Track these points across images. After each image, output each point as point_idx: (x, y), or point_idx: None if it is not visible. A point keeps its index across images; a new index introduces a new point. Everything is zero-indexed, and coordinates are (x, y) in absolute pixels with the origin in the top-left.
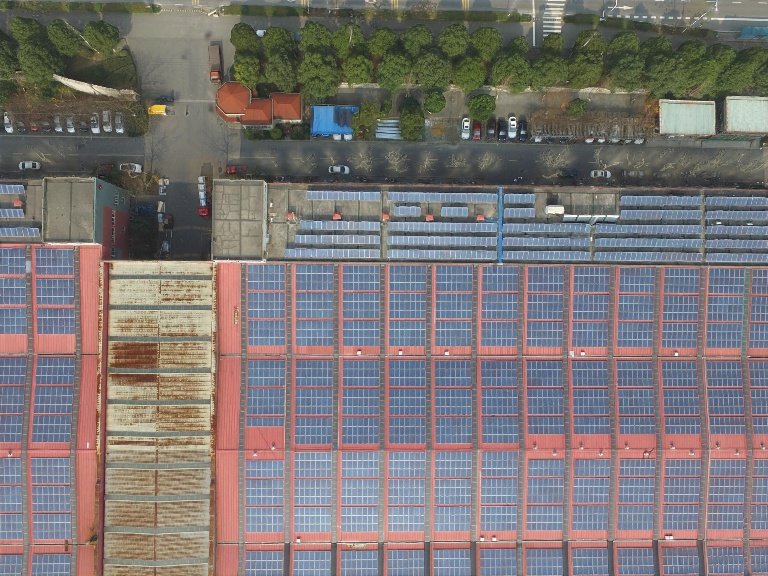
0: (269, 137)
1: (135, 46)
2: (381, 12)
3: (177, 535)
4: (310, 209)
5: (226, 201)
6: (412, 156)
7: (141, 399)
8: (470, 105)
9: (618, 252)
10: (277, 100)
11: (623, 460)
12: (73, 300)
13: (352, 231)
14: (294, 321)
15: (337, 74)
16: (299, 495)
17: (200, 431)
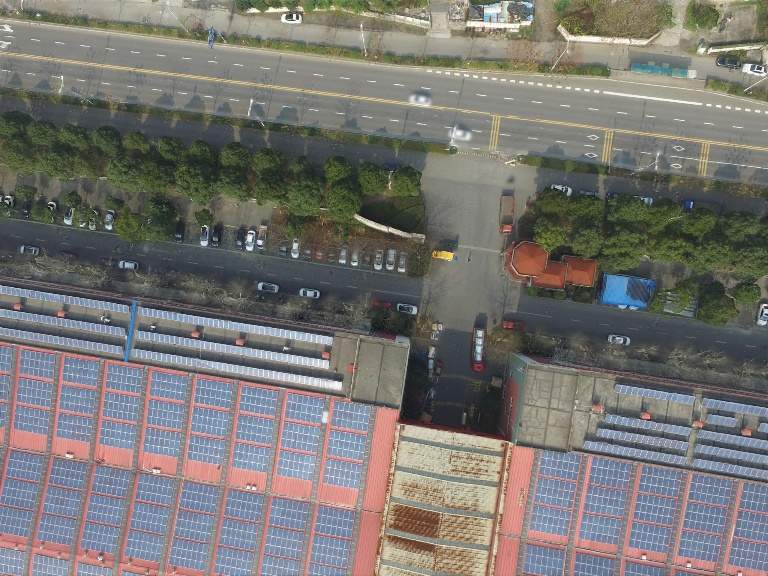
0: (551, 296)
1: (426, 185)
2: (688, 180)
3: None
4: (615, 401)
5: (537, 386)
6: (699, 335)
7: (416, 566)
8: None
9: None
10: (572, 265)
11: None
12: (362, 456)
13: (657, 431)
14: (581, 513)
15: None
16: None
17: None
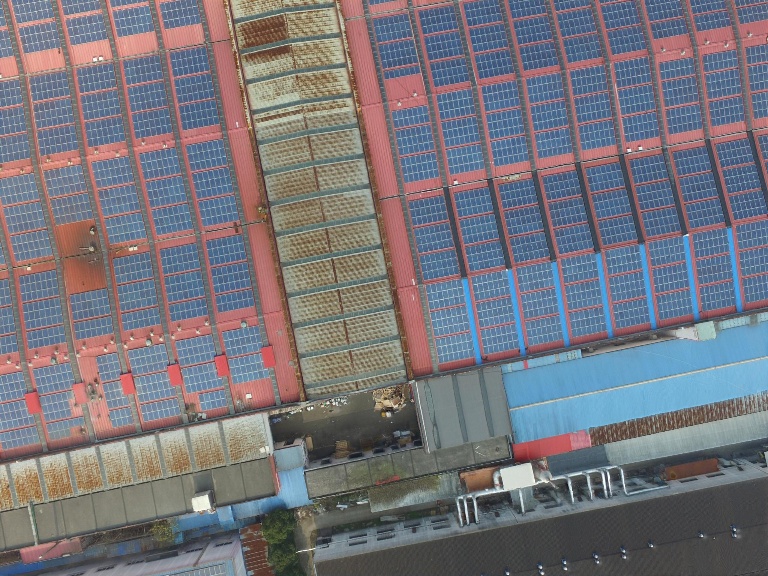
0: None
1: None
2: None
3: (340, 196)
4: None
5: None
6: None
7: (279, 72)
8: None
9: None
10: None
11: (748, 48)
12: None
13: None
14: None
15: None
16: (448, 137)
17: (341, 94)
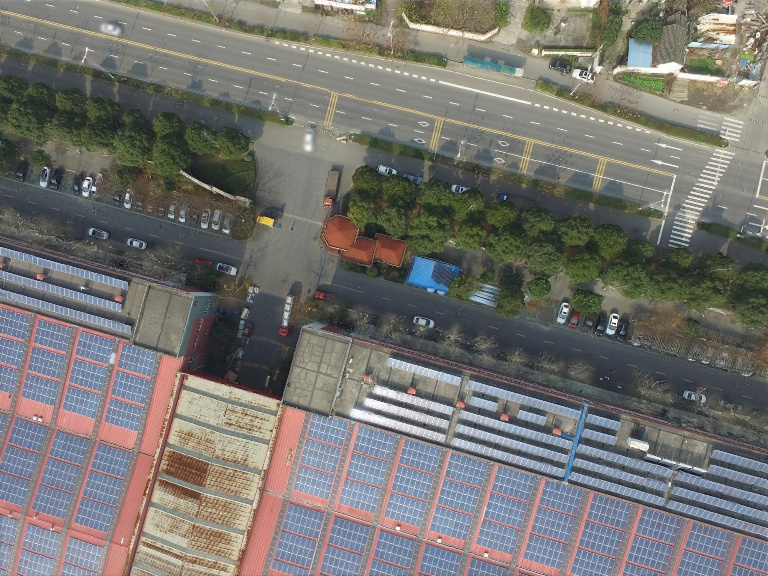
0: (364, 272)
1: (261, 152)
2: (507, 175)
3: None
4: (387, 374)
5: (309, 350)
6: (501, 326)
7: (181, 512)
8: (575, 299)
9: (695, 507)
10: (382, 243)
11: None
12: (144, 400)
13: (423, 408)
14: (343, 479)
15: (447, 234)
16: None
17: (227, 558)
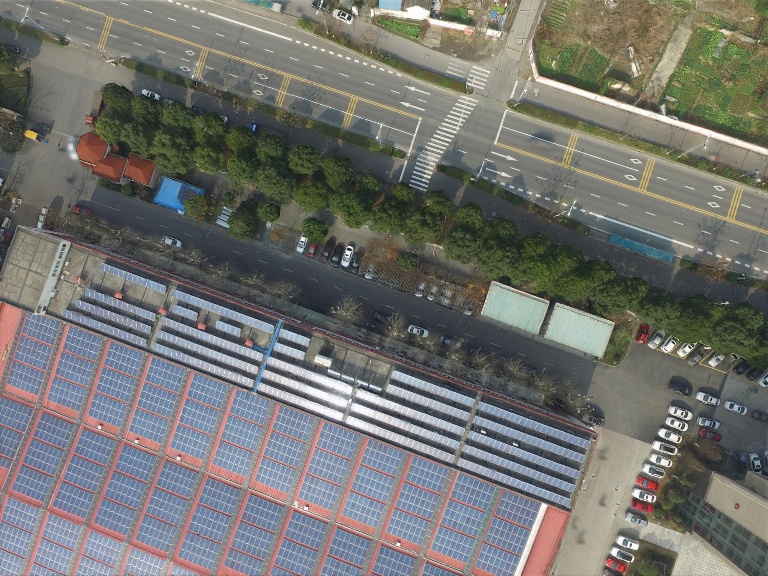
0: None
1: (36, 70)
2: (262, 106)
3: None
4: (101, 279)
5: (23, 248)
6: (244, 251)
7: None
8: (302, 225)
9: (370, 424)
10: (131, 161)
11: None
12: None
13: (130, 313)
14: (53, 376)
15: (189, 156)
16: (1, 537)
17: None
